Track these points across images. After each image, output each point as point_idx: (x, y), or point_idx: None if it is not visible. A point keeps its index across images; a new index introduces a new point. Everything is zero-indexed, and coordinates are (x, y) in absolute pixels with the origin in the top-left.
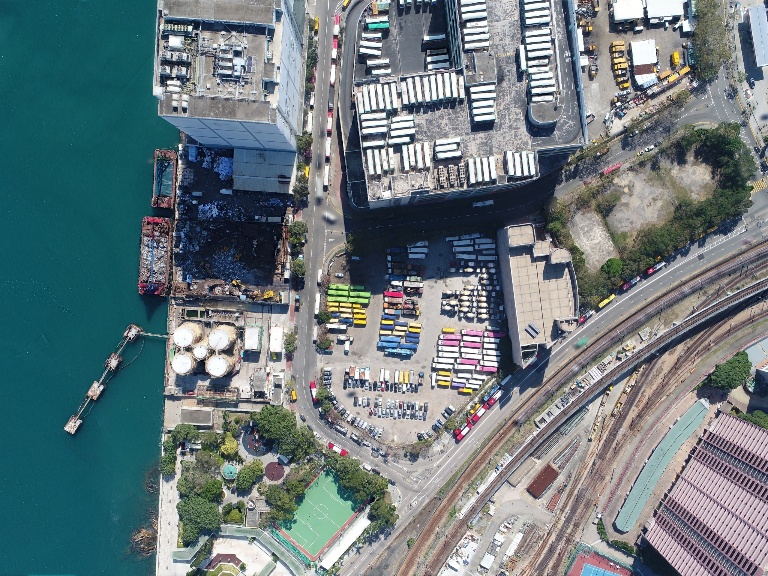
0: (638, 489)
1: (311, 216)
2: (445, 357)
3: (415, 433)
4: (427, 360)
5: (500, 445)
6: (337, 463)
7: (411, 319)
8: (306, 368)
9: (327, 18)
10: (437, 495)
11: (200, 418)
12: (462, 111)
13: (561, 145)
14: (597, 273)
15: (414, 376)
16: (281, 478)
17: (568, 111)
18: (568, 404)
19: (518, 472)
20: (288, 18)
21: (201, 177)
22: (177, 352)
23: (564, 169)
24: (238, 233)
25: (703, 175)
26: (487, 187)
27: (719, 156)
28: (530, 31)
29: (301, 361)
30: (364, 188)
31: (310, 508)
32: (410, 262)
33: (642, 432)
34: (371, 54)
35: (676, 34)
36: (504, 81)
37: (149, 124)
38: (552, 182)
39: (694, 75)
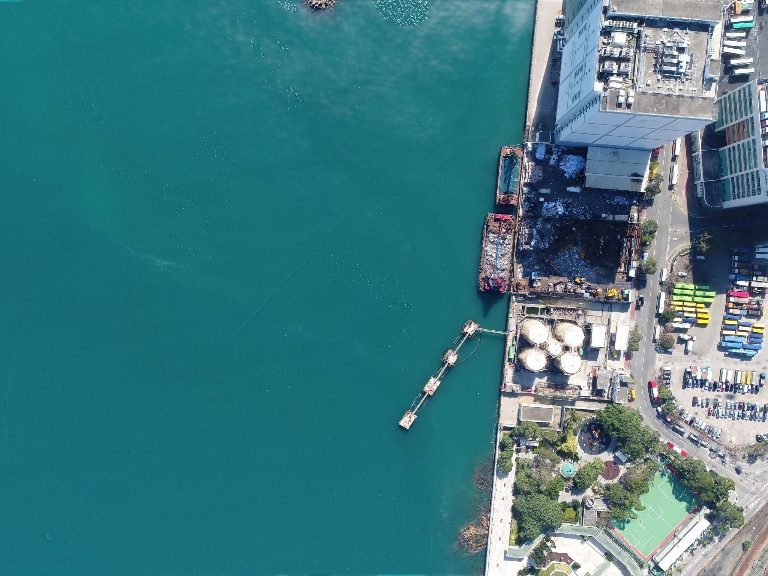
0: None
1: (655, 215)
2: None
3: (753, 434)
4: None
5: None
6: (682, 463)
7: (753, 319)
8: (645, 367)
9: None
10: None
11: (541, 415)
12: None
13: None
14: None
15: None
16: (616, 477)
17: None
18: None
19: None
20: None
21: (547, 175)
22: (532, 349)
23: None
24: (582, 231)
25: None
26: None
27: None
28: None
29: (640, 360)
30: (717, 187)
31: None
32: (754, 262)
33: None
34: (734, 53)
35: None
36: None
37: (493, 121)
38: None
39: None
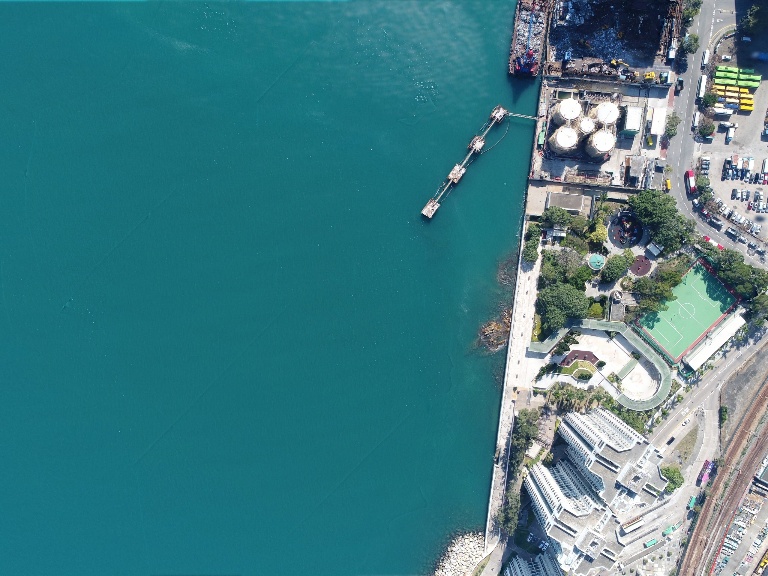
0: None
1: None
2: None
3: None
4: None
5: None
6: (719, 254)
7: None
8: (682, 157)
9: None
10: None
11: (570, 203)
12: None
13: None
14: None
15: None
16: (647, 273)
17: None
18: None
19: None
20: None
21: None
22: (563, 125)
23: None
24: (621, 10)
25: None
26: None
27: None
28: None
29: (677, 149)
30: None
31: (675, 306)
32: None
33: None
34: None
35: None
36: None
37: None
38: None
39: None
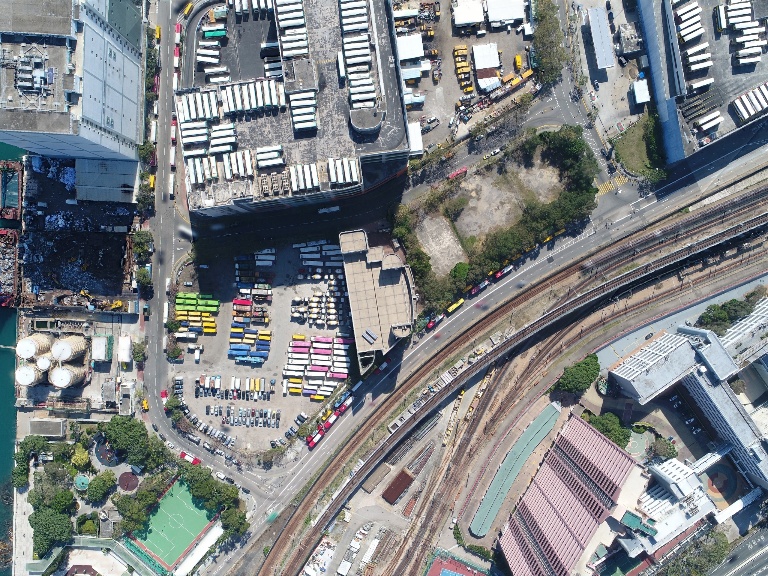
0: (492, 493)
1: (158, 225)
2: (295, 364)
3: (268, 441)
4: (278, 367)
5: (354, 451)
6: (187, 472)
7: (261, 327)
8: (158, 377)
9: (169, 26)
10: (292, 503)
11: (50, 429)
12: (285, 118)
13: (385, 151)
14: (447, 278)
15: (266, 384)
16: (135, 488)
17: (392, 117)
18: (417, 409)
19: (372, 478)
20: (100, 28)
21: (47, 188)
22: (20, 364)
23: (408, 174)
24: (85, 243)
25: (550, 178)
26: (314, 194)
27: (564, 159)
28: (350, 37)
29: (152, 370)
30: None
31: (165, 518)
32: (259, 269)
33: (496, 436)
34: (209, 62)
35: (519, 37)
36: (326, 88)
37: None
38: (399, 187)
39: (537, 78)
